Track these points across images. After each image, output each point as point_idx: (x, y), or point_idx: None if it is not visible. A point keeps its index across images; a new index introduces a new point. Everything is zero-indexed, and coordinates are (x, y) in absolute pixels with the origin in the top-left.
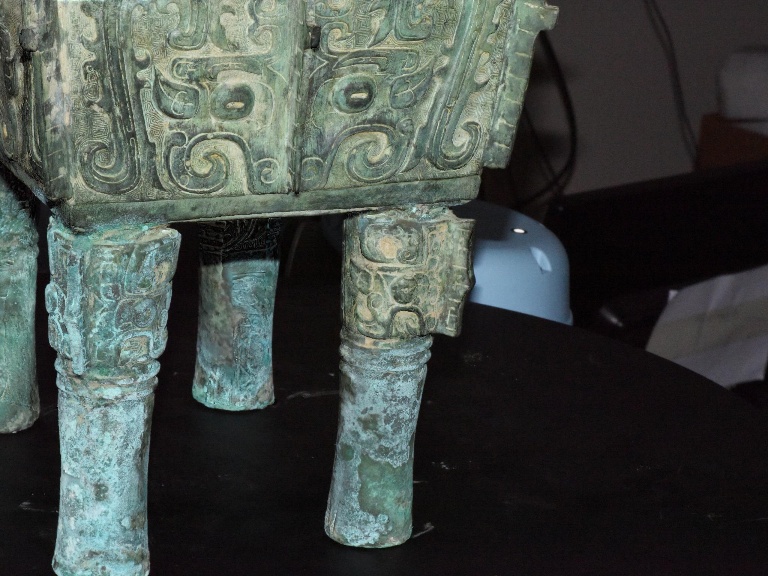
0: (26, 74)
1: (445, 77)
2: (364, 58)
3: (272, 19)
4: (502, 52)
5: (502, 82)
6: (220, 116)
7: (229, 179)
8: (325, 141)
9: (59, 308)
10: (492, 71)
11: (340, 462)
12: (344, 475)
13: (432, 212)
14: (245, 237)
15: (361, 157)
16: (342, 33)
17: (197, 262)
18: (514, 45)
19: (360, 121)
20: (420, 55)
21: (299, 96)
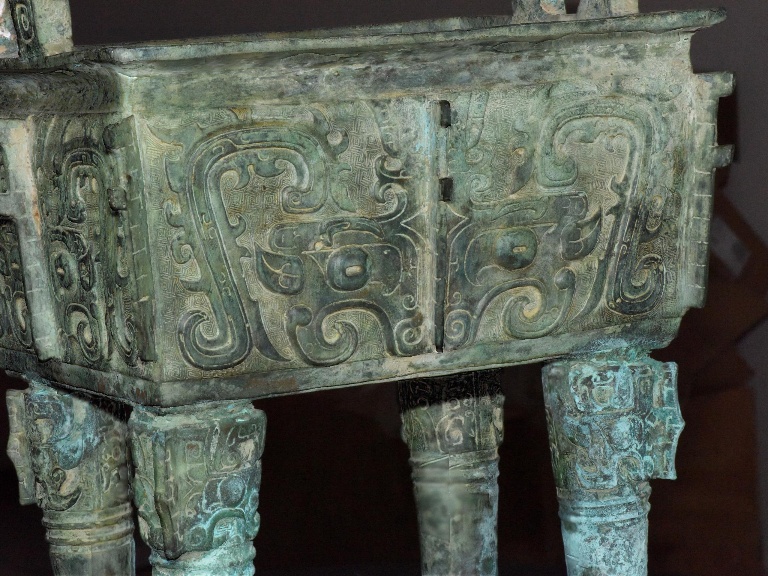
0: (633, 217)
1: None
2: None
3: None
4: None
5: None
6: None
7: None
8: None
9: None
10: None
11: None
12: None
13: None
14: None
15: None
16: None
17: (101, 568)
18: None
19: None
20: None
21: None
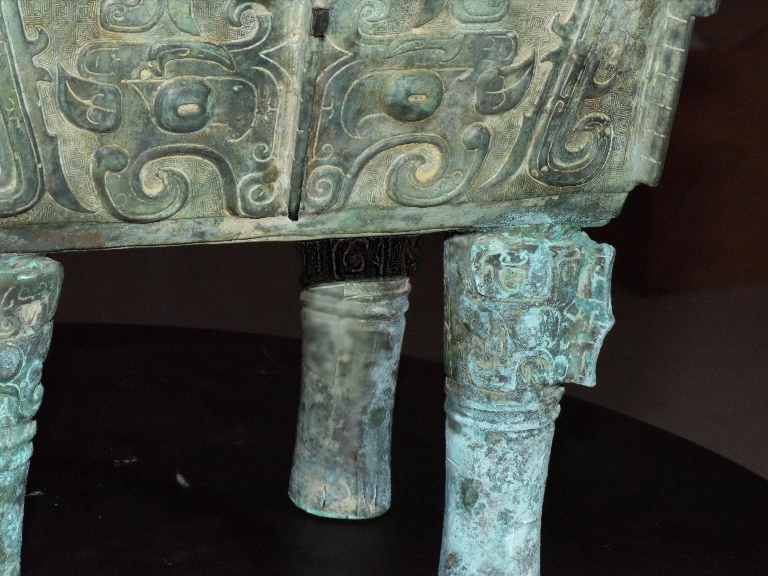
0: (577, 67)
1: None
2: None
3: None
4: None
5: None
6: None
7: None
8: None
9: (549, 333)
10: None
11: (372, 432)
12: (378, 443)
13: None
14: None
15: None
16: None
17: None
18: None
19: None
20: None
21: None
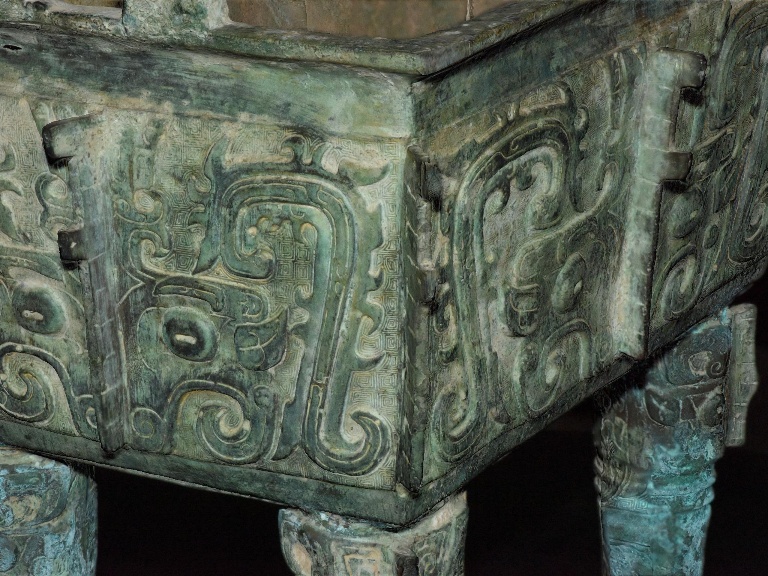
0: None
1: (308, 339)
2: (187, 288)
3: (65, 210)
4: (399, 321)
5: (404, 365)
6: (21, 325)
7: (55, 410)
8: (161, 390)
9: None
10: (387, 346)
11: None
12: None
13: (353, 527)
14: (619, 492)
15: (210, 424)
16: (156, 247)
17: None
18: (407, 314)
19: (202, 374)
20: (267, 300)
21: (85, 321)
